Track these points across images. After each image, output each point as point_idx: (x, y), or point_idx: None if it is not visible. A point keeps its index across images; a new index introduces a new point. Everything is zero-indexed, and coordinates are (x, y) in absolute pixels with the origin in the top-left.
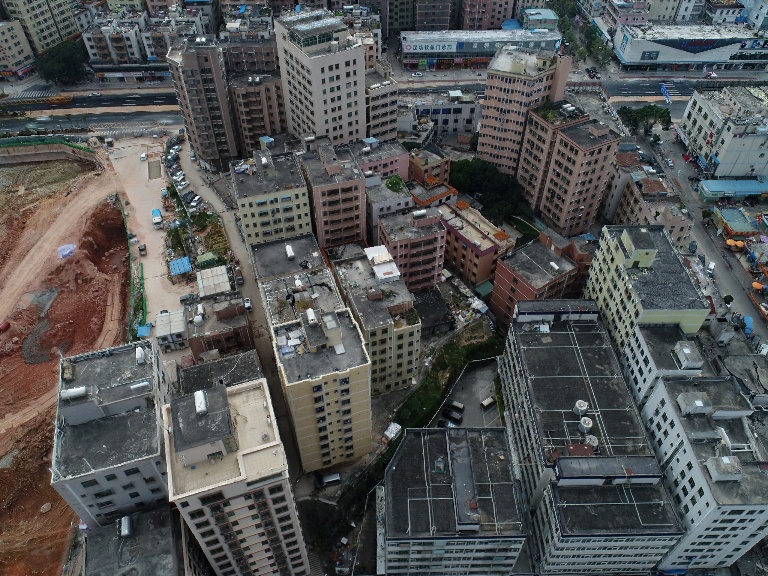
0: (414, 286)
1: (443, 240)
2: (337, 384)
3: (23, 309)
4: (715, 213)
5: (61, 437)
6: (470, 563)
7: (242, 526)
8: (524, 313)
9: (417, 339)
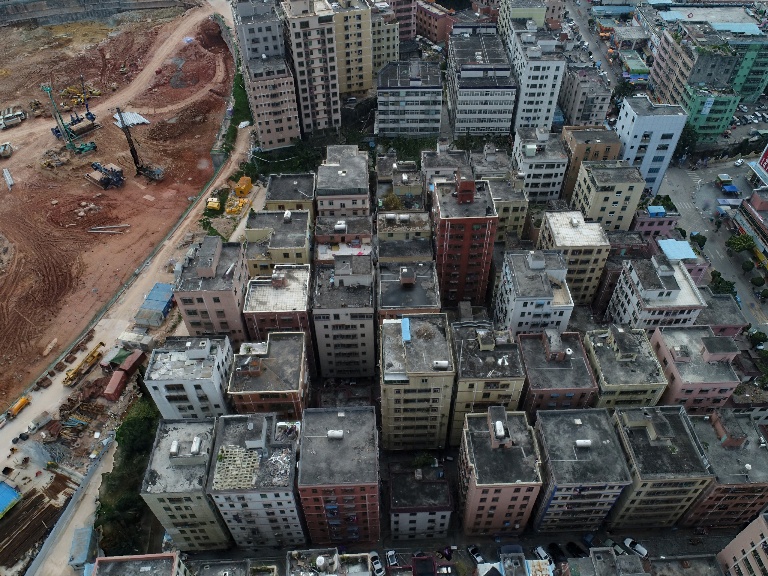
0: (399, 36)
1: (415, 3)
2: (355, 20)
3: (168, 64)
4: (596, 21)
5: (237, 19)
6: (419, 118)
7: (314, 56)
8: (456, 27)
9: (397, 35)
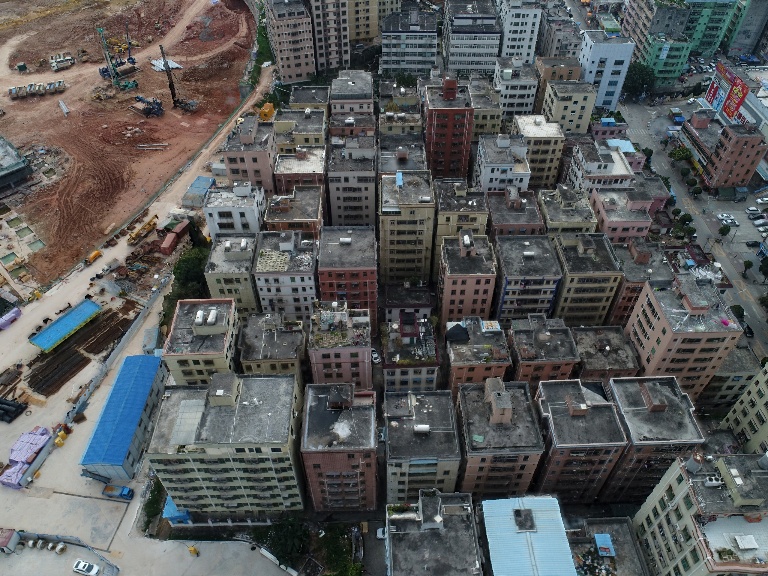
0: None
1: None
2: None
3: (197, 21)
4: None
5: None
6: (417, 59)
7: (329, 2)
8: None
9: None
